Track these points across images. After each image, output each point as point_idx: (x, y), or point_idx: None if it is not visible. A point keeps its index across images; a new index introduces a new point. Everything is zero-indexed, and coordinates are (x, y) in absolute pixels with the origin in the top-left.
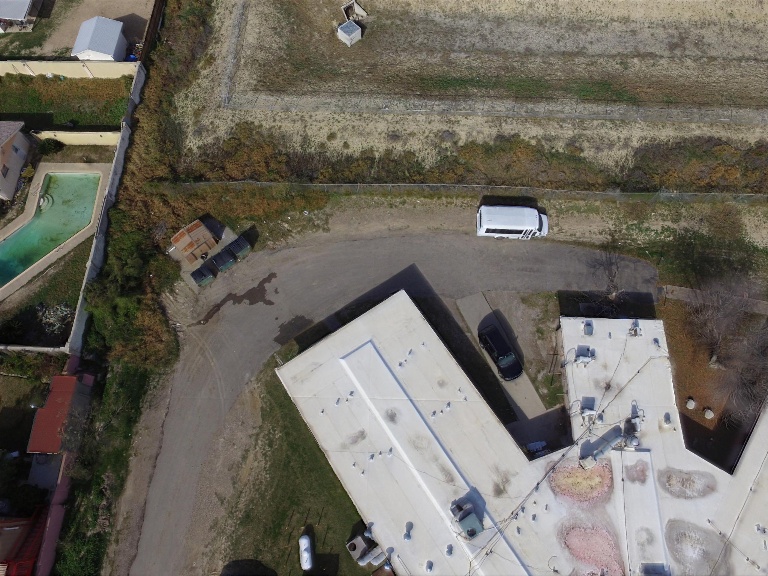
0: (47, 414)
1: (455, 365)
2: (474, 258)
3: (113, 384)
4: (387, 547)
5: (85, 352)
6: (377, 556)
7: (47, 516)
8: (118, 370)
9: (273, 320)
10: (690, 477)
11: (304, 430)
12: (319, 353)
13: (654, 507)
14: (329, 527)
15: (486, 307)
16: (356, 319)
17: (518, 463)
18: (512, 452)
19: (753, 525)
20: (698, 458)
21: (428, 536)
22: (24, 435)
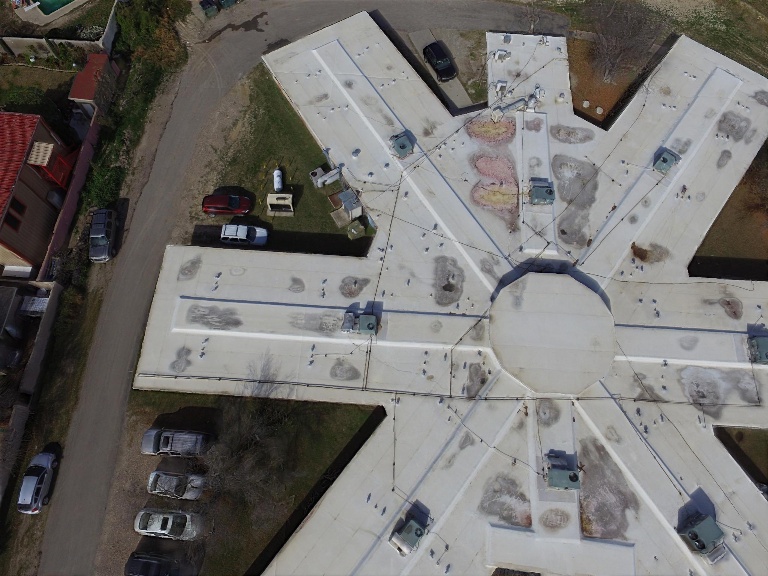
0: (84, 76)
1: (401, 58)
2: (425, 8)
3: (135, 75)
4: (340, 163)
5: (114, 53)
6: (332, 176)
7: (81, 145)
8: (139, 67)
9: (263, 41)
10: (575, 131)
11: (282, 109)
12: (296, 46)
13: (545, 145)
14: (298, 168)
15: (432, 38)
16: (327, 27)
17: (444, 117)
18: (440, 111)
19: (619, 160)
20: (583, 120)
21: (371, 158)
22: (64, 106)
